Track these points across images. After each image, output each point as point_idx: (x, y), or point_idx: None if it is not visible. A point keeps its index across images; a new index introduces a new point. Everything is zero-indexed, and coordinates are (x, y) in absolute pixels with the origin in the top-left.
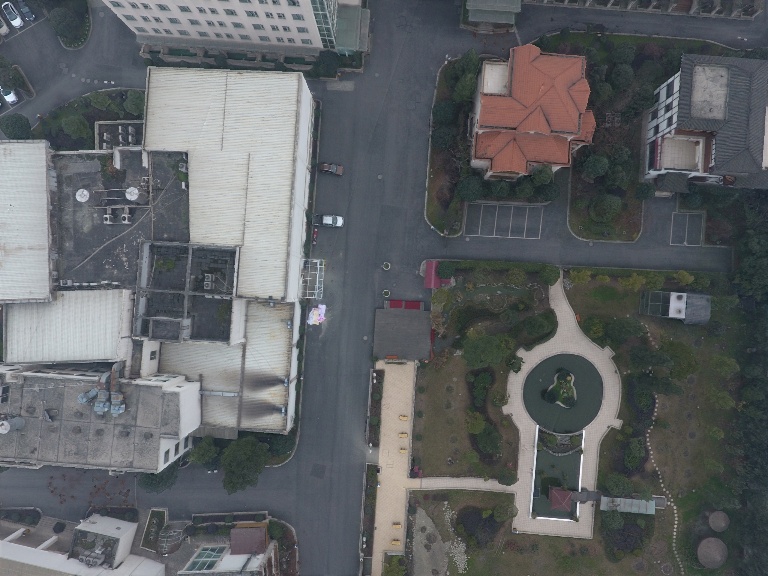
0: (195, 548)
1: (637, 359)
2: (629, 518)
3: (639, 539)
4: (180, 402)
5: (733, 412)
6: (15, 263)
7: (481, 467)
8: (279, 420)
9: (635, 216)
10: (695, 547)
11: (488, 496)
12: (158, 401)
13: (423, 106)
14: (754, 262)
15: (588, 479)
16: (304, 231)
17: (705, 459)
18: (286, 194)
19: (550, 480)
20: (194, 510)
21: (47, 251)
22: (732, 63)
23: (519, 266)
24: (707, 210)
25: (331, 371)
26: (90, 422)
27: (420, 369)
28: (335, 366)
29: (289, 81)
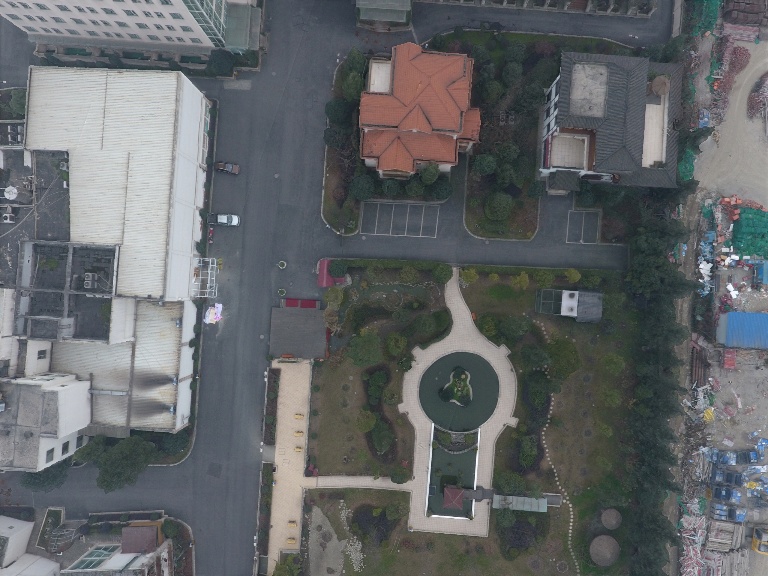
0: (89, 547)
1: (526, 357)
2: (524, 516)
3: (534, 537)
4: (59, 401)
5: (628, 410)
6: None
7: (377, 465)
8: (169, 419)
9: (531, 214)
10: (589, 545)
11: (384, 494)
12: (38, 400)
13: (320, 105)
14: (642, 260)
15: (484, 477)
16: (198, 230)
17: (597, 457)
18: (165, 193)
19: (448, 478)
20: (91, 509)
21: None
22: (611, 61)
23: (413, 264)
24: (603, 208)
25: (228, 370)
26: None
27: (316, 368)
28: (232, 365)
29: (168, 80)
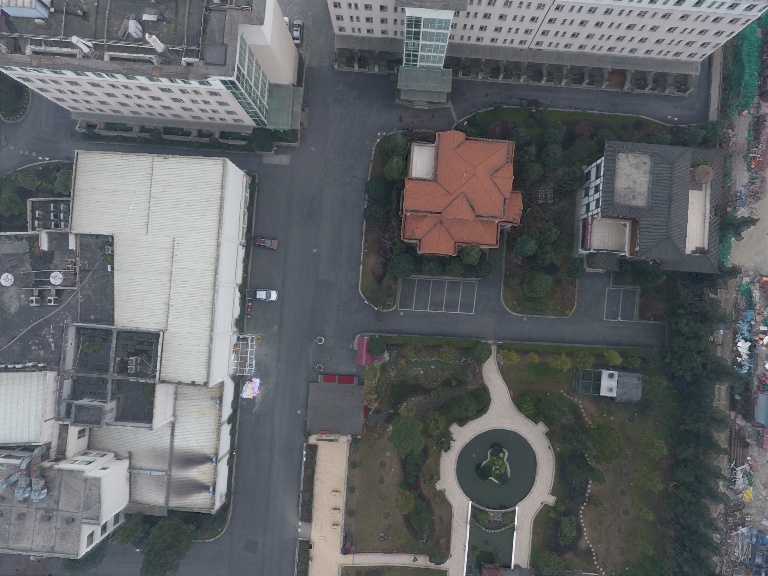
0: None
1: (566, 439)
2: None
3: None
4: (101, 487)
5: (666, 490)
6: None
7: (414, 543)
8: (207, 498)
9: (569, 291)
10: None
11: (421, 572)
12: (80, 485)
13: (358, 180)
14: (683, 343)
15: (521, 556)
16: (237, 306)
17: (636, 539)
18: (210, 279)
19: (484, 555)
20: None
21: None
22: (655, 151)
23: (451, 342)
24: (641, 286)
25: (264, 445)
26: (12, 506)
27: (353, 444)
28: (268, 440)
29: (214, 166)
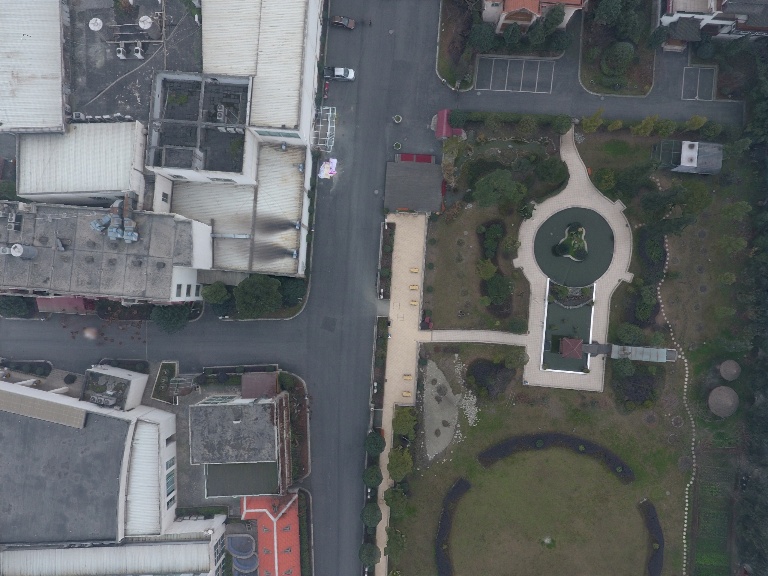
0: (206, 397)
1: (649, 203)
2: (640, 370)
3: (650, 391)
4: (193, 230)
5: (744, 264)
6: (28, 92)
7: (492, 320)
8: (290, 264)
9: (646, 71)
10: (706, 398)
11: (499, 349)
12: (171, 231)
13: None
14: (766, 106)
15: (599, 332)
16: (315, 82)
17: (716, 308)
18: (299, 23)
19: (560, 337)
20: (205, 363)
21: (60, 80)
22: None
23: None
24: (719, 64)
25: (342, 225)
26: (103, 252)
27: (431, 222)
28: (346, 220)
29: None
